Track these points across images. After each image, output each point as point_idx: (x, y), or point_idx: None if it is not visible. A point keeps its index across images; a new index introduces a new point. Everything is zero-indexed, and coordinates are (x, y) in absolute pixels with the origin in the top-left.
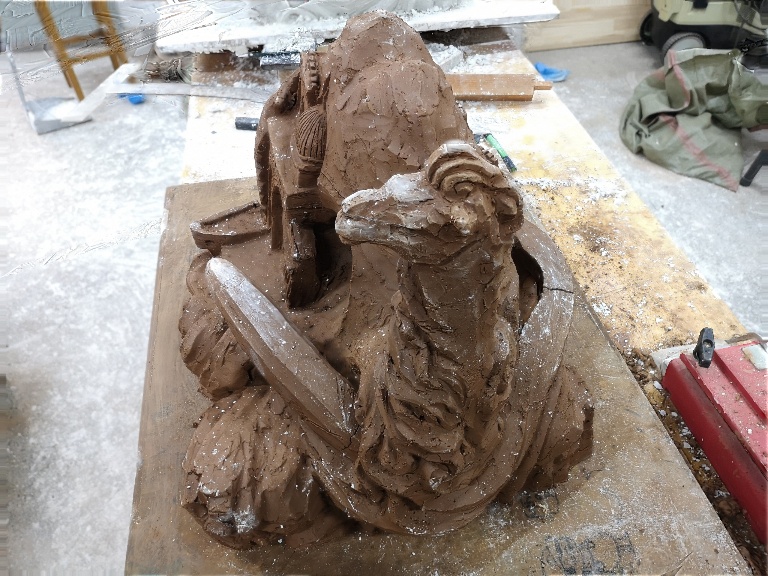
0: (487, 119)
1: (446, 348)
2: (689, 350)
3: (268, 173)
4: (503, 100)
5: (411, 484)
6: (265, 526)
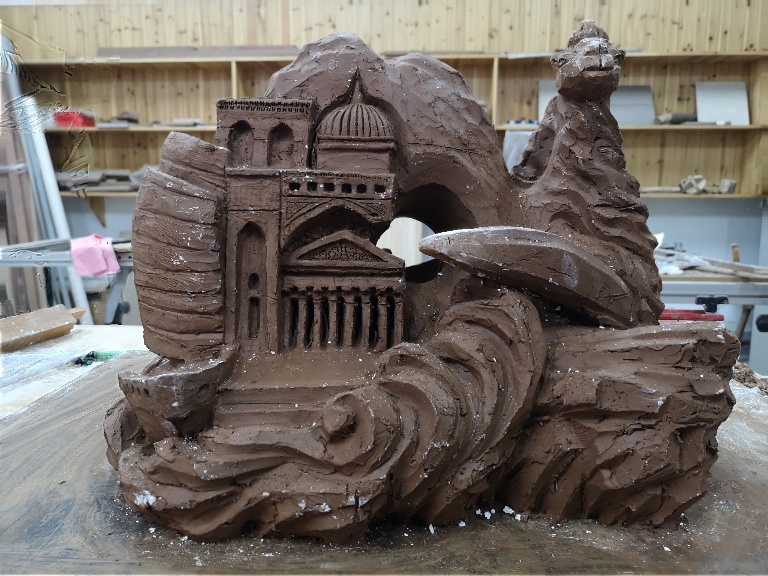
0: (61, 351)
1: None
2: None
3: (228, 253)
4: (42, 341)
5: None
6: None
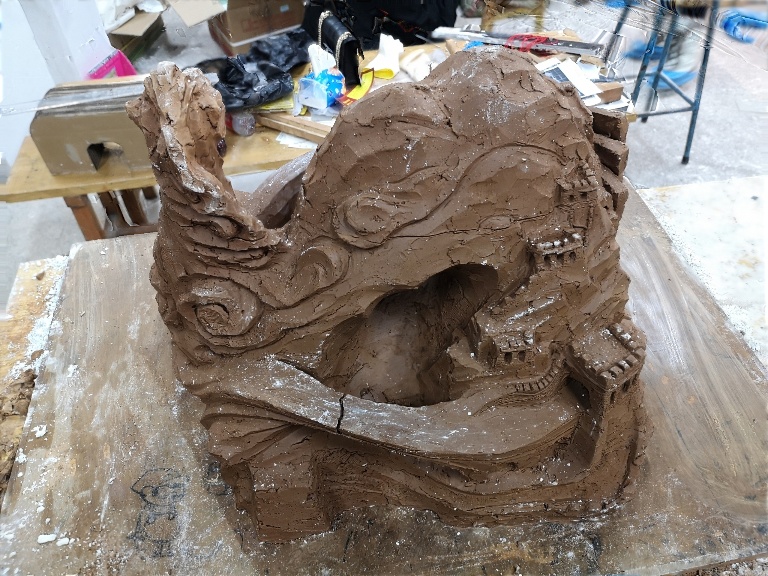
0: None
1: None
2: None
3: None
4: None
5: None
6: None
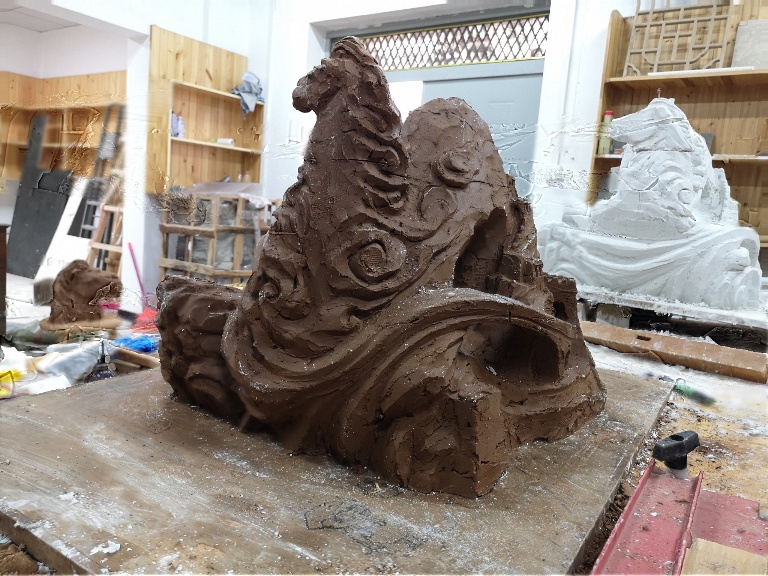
0: (695, 377)
1: (307, 172)
2: None
3: None
4: (731, 376)
5: (254, 303)
6: (177, 327)
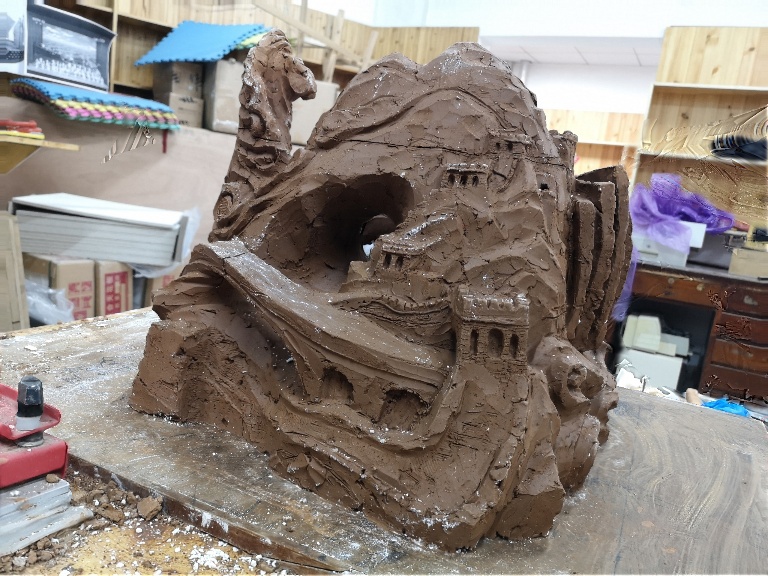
0: None
1: None
2: (25, 521)
3: None
4: None
5: None
6: None
